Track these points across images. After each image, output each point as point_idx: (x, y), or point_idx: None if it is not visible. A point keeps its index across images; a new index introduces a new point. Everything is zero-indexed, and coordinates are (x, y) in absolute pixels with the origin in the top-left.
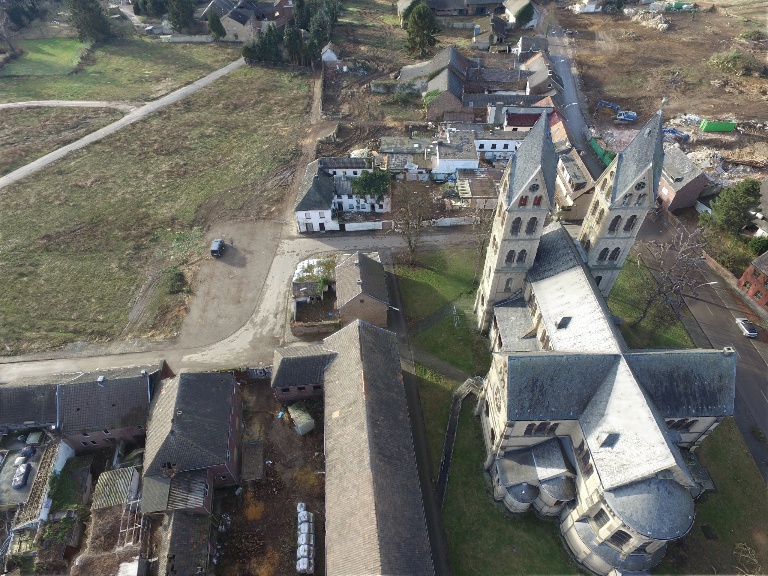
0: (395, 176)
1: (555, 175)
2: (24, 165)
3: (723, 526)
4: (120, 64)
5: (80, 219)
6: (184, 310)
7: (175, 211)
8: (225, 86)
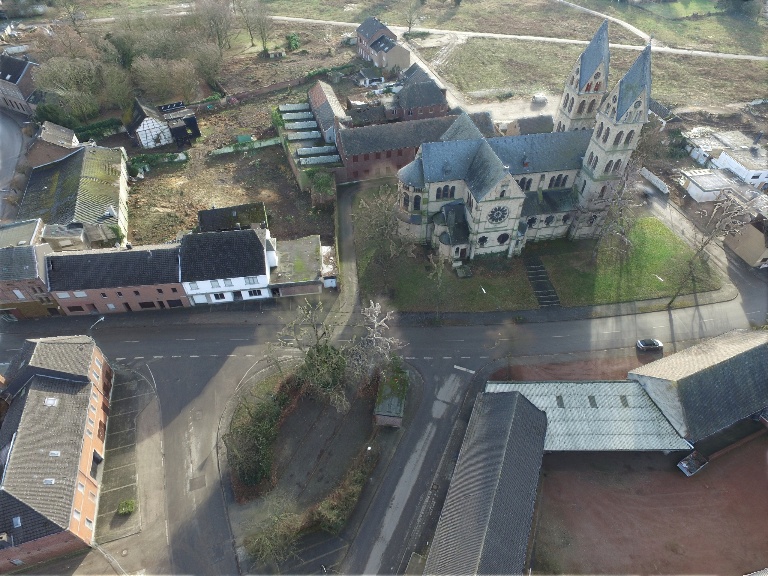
0: (686, 146)
1: (594, 71)
2: (559, 38)
3: (436, 275)
4: (707, 27)
5: (531, 63)
6: (488, 102)
7: (562, 83)
8: (733, 64)
